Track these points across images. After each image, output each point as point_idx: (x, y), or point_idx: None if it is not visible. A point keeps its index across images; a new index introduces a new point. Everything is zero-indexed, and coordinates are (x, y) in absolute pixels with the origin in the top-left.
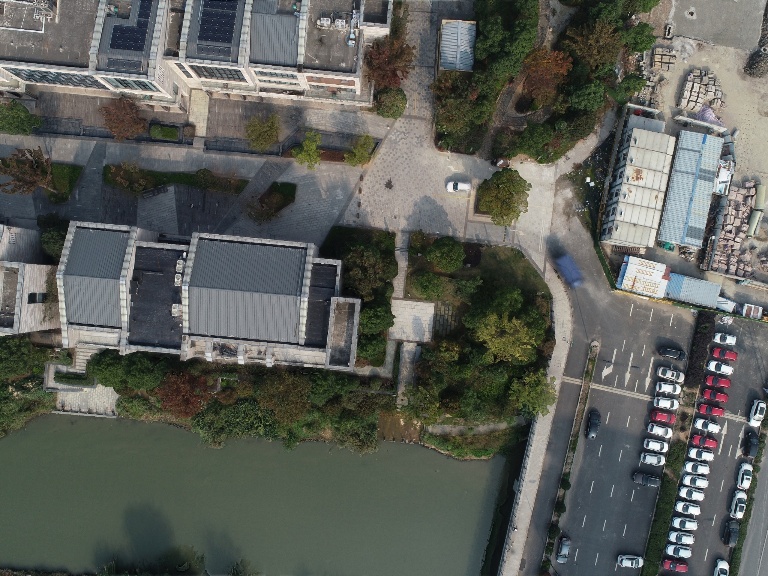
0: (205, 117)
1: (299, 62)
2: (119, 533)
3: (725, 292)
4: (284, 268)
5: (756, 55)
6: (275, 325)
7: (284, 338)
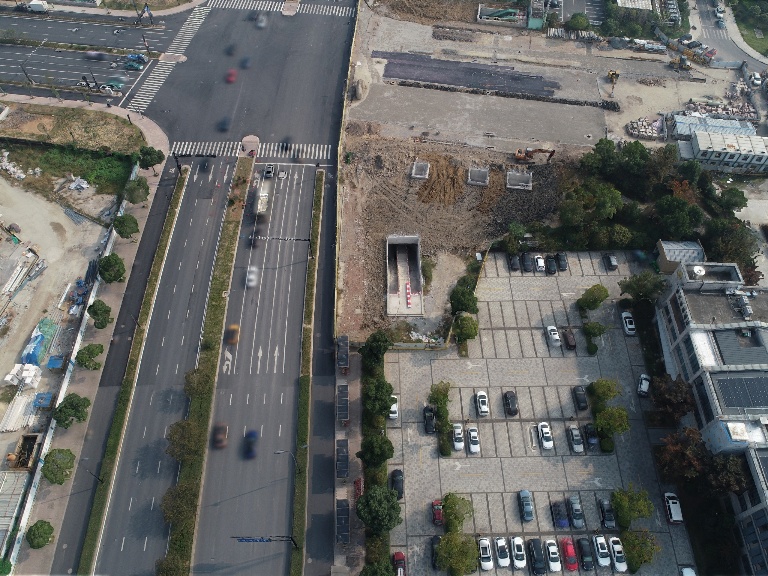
0: None
1: None
2: None
3: (765, 115)
4: None
5: (606, 107)
6: None
7: None
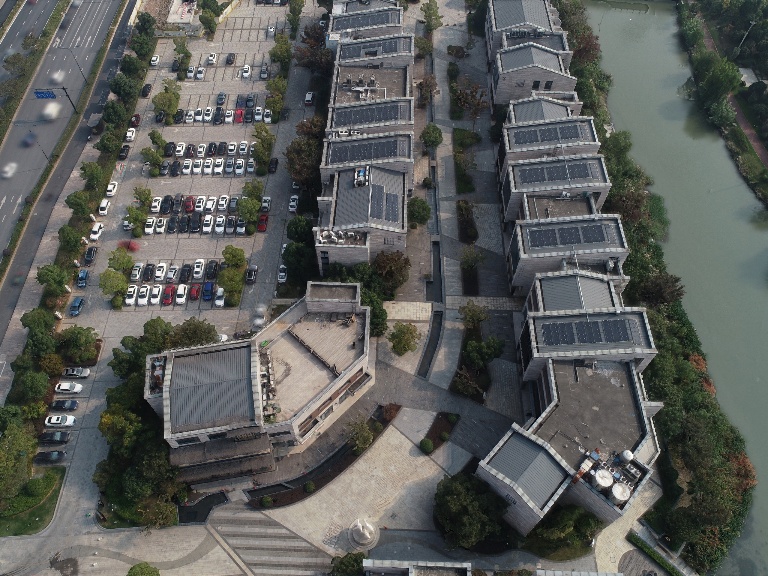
0: (413, 80)
1: (394, 1)
2: (687, 123)
3: None
4: (505, 2)
5: None
6: (537, 5)
7: (543, 4)
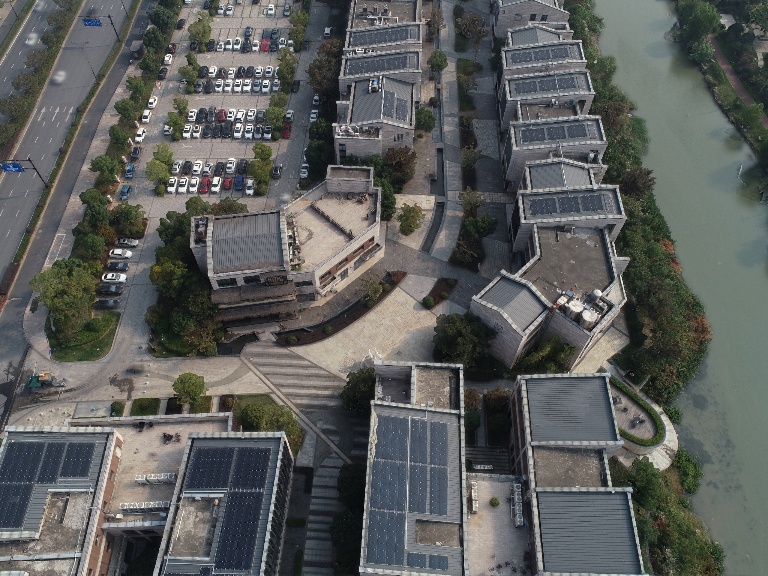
0: (422, 19)
1: None
2: (670, 60)
3: None
4: None
5: None
6: None
7: None
